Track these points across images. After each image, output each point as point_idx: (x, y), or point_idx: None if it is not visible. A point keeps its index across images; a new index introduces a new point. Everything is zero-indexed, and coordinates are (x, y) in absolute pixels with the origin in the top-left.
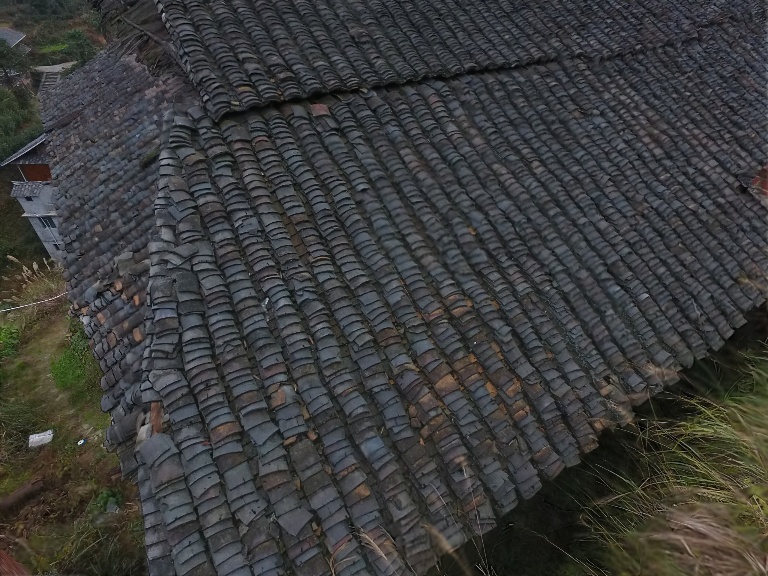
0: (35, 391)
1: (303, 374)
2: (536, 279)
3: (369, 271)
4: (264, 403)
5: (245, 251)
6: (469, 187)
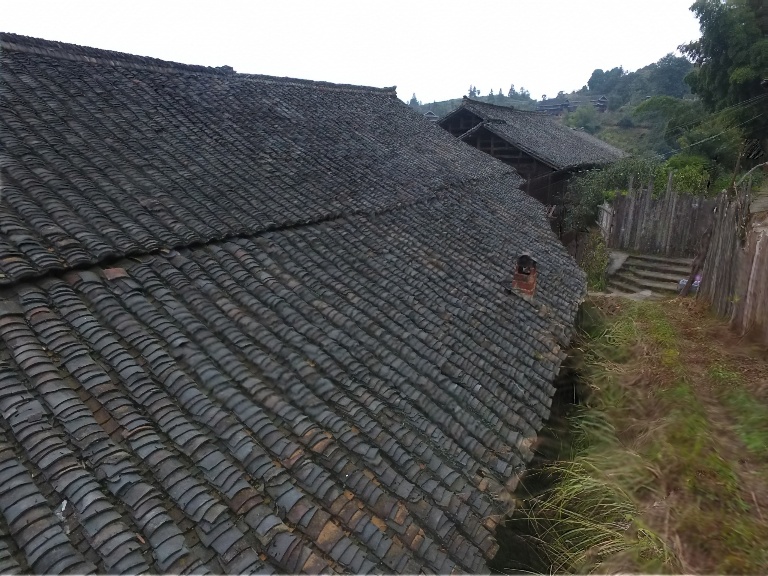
0: None
1: None
2: (385, 394)
3: (206, 430)
4: None
5: (23, 446)
6: (296, 324)
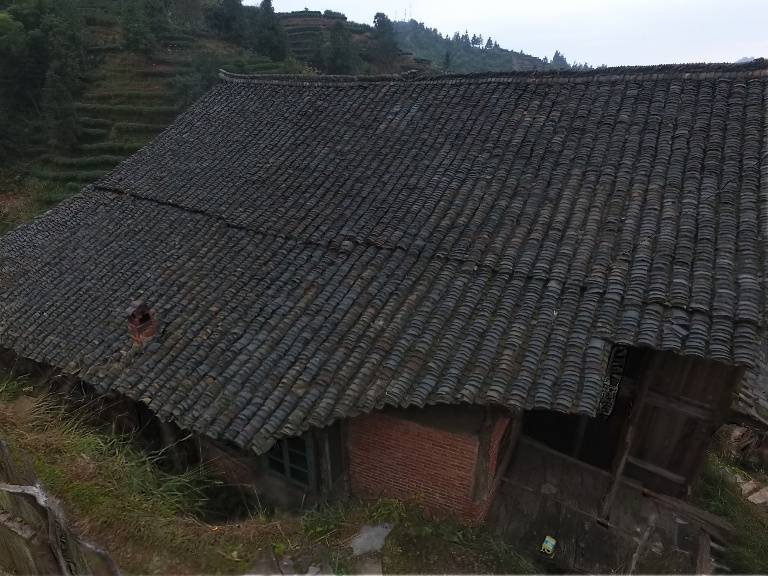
0: None
1: None
2: None
3: None
4: None
5: None
6: None
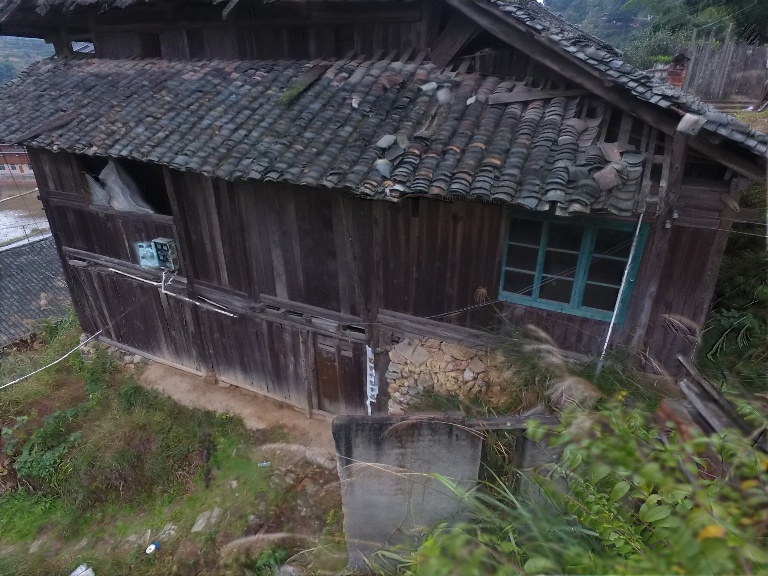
0: None
1: None
2: None
3: None
4: None
5: None
6: None
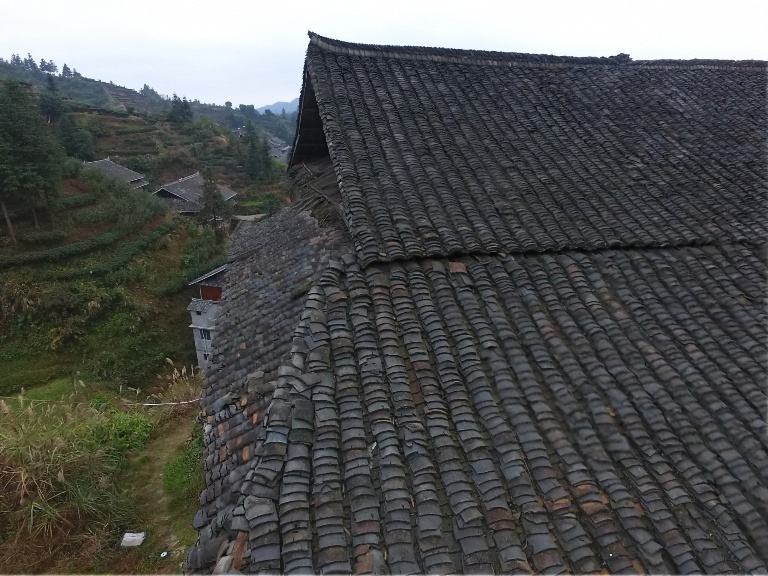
0: (145, 488)
1: (397, 541)
2: (696, 487)
3: (486, 435)
4: (349, 565)
5: (364, 389)
6: (609, 362)
